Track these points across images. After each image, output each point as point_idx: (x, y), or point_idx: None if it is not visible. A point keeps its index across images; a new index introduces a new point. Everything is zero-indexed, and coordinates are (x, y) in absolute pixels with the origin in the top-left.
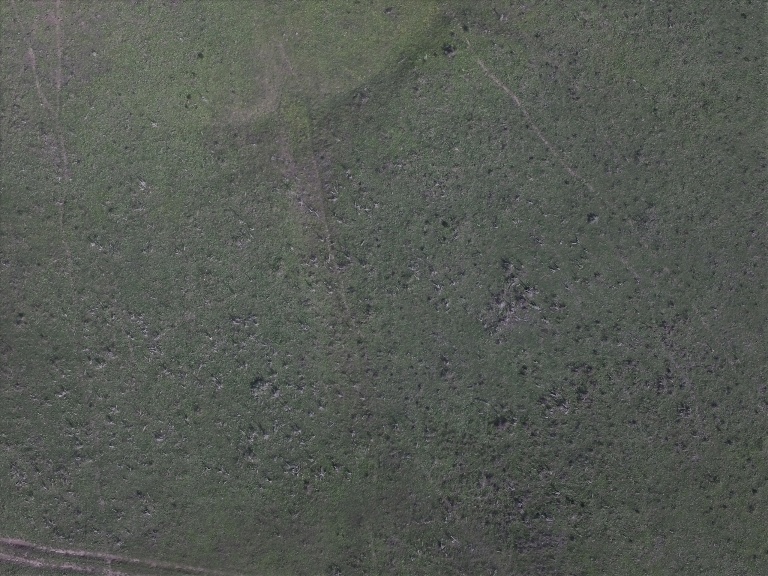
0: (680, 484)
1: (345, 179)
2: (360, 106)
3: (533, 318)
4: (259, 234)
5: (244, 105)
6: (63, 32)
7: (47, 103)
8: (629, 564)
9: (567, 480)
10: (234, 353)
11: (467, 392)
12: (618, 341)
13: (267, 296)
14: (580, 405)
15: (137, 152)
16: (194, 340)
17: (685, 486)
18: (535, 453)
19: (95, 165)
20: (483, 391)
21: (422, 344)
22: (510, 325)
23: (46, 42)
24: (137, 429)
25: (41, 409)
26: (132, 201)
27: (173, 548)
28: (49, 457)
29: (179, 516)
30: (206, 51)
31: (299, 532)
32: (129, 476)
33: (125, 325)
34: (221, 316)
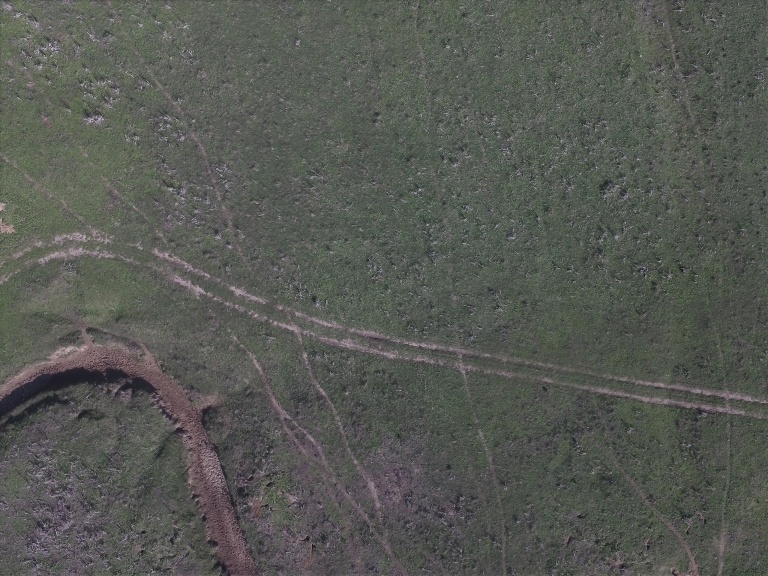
0: None
1: None
2: None
3: None
4: (607, 42)
5: None
6: None
7: None
8: None
9: None
10: (583, 156)
11: None
12: None
13: (616, 101)
14: None
15: None
16: (544, 142)
17: None
18: None
19: None
20: None
21: (767, 152)
22: None
23: None
24: (488, 228)
25: (396, 206)
26: (484, 7)
27: (523, 344)
28: (403, 252)
29: (529, 313)
30: None
31: (647, 331)
32: (481, 273)
33: (477, 126)
34: (571, 120)
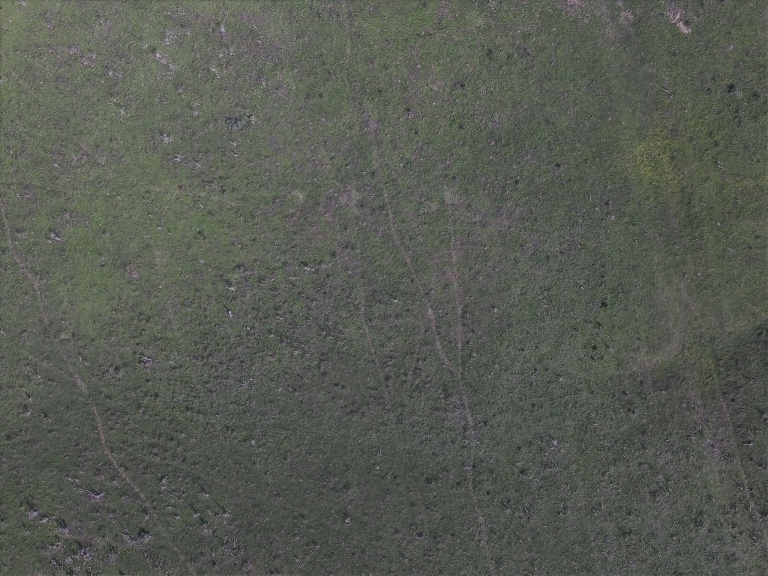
0: None
1: (761, 422)
2: (767, 344)
3: None
4: (676, 486)
5: (650, 351)
6: (461, 289)
7: (449, 364)
8: None
9: None
10: None
11: None
12: None
13: (692, 552)
14: None
15: (545, 409)
16: None
17: None
18: None
19: (502, 425)
20: None
21: None
22: None
23: (445, 301)
24: None
25: None
26: (543, 460)
27: None
28: None
29: None
30: (609, 299)
31: None
32: None
33: None
34: None
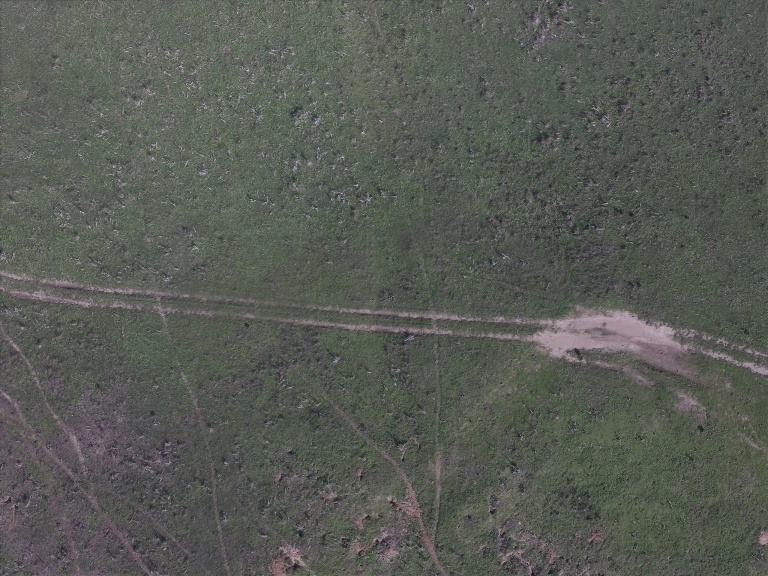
0: (727, 189)
1: None
2: None
3: (569, 34)
4: None
5: None
6: None
7: None
8: (682, 269)
9: (614, 191)
10: (272, 84)
11: (508, 112)
12: (655, 52)
13: (301, 26)
14: (622, 117)
15: None
16: (231, 74)
17: (732, 190)
18: (580, 167)
19: None
20: (524, 110)
21: (460, 66)
22: (546, 43)
23: None
24: (179, 165)
25: (81, 150)
26: None
27: (222, 281)
28: (92, 197)
29: (226, 249)
30: None
31: (349, 258)
32: (174, 212)
33: (160, 62)
34: (256, 48)
